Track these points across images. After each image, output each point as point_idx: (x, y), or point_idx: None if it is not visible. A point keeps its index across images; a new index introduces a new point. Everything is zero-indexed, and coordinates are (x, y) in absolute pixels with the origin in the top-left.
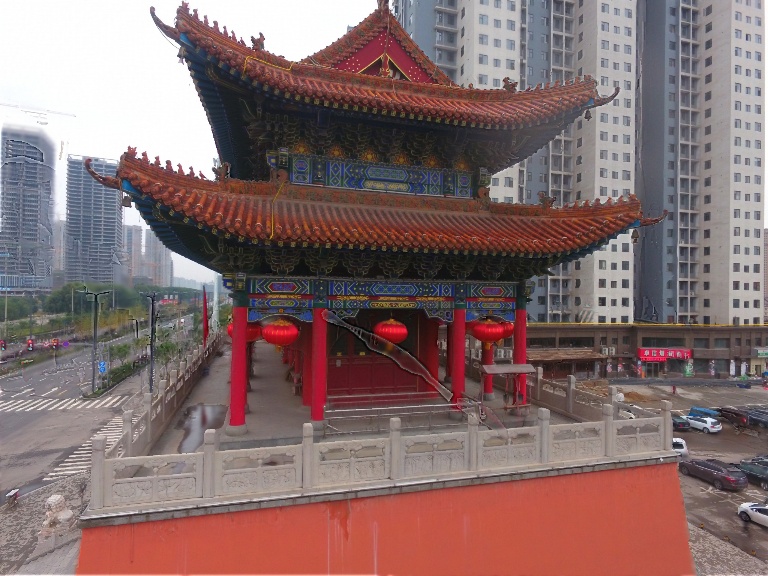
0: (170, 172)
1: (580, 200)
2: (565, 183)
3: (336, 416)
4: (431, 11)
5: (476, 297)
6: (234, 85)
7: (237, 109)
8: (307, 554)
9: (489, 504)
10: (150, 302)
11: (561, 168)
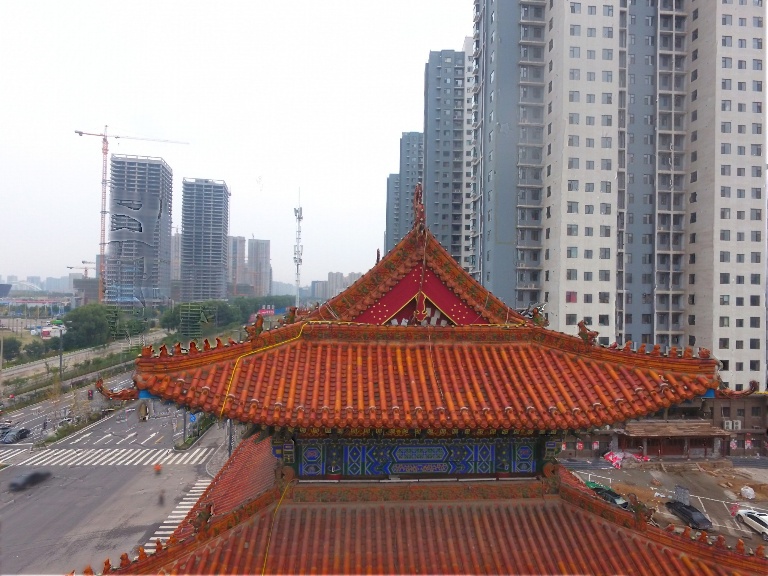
0: (126, 569)
1: (695, 244)
2: (675, 223)
3: None
4: (515, 46)
5: None
6: None
7: None
8: None
9: None
10: None
11: (670, 207)
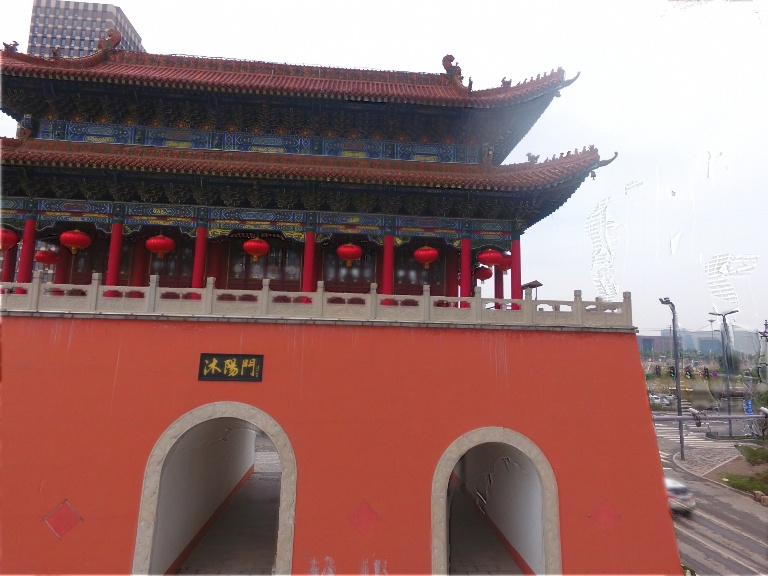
0: None
1: None
2: None
3: None
4: None
5: None
6: None
7: None
8: None
9: None
10: (670, 311)
11: None
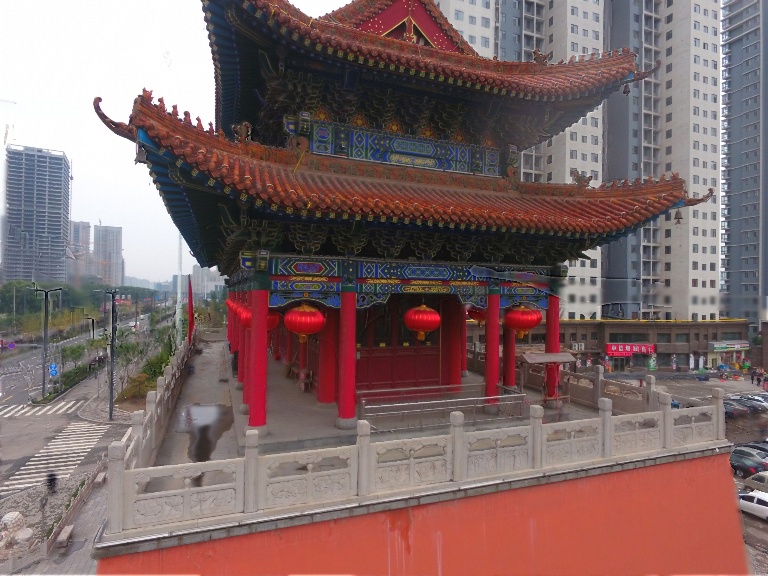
0: (189, 126)
1: None
2: None
3: (376, 412)
4: None
5: (510, 282)
6: (256, 33)
7: (252, 66)
8: (365, 573)
9: (554, 505)
10: (110, 299)
11: (532, 167)
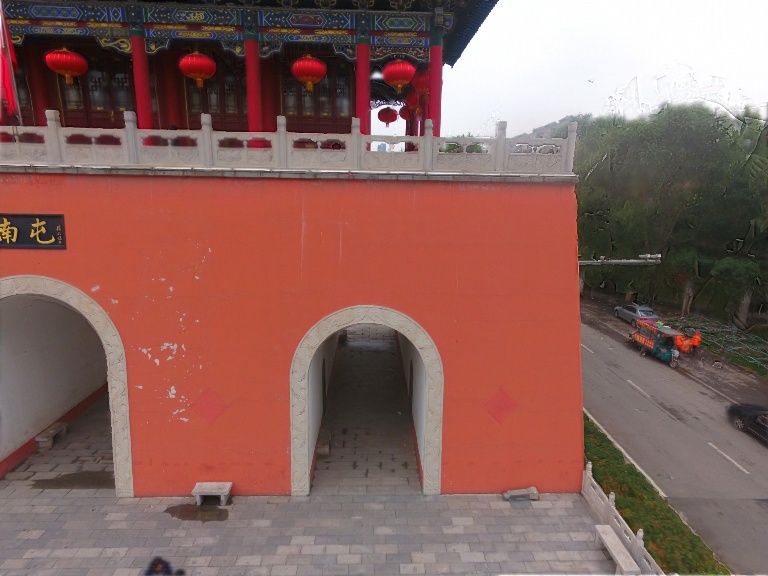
0: None
1: None
2: None
3: None
4: None
5: None
6: None
7: None
8: None
9: None
10: None
11: None
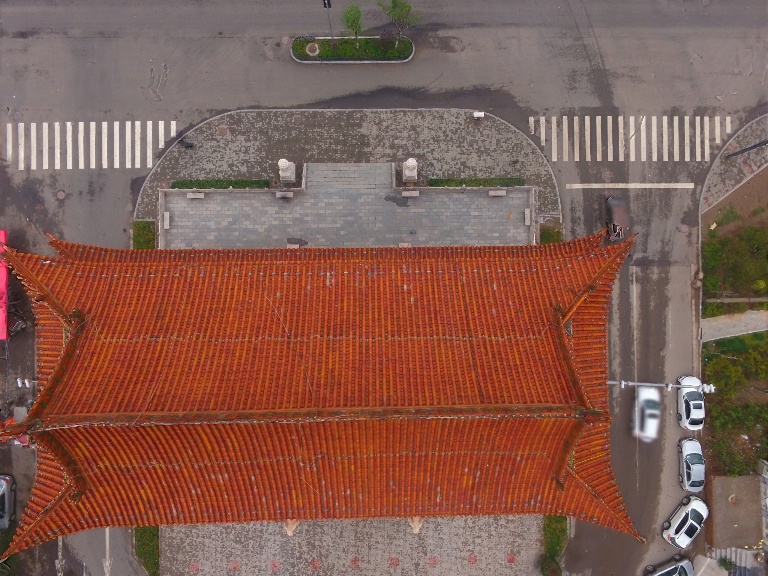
0: None
1: None
2: None
3: None
4: None
5: None
6: None
7: None
8: None
9: None
10: None
11: None
